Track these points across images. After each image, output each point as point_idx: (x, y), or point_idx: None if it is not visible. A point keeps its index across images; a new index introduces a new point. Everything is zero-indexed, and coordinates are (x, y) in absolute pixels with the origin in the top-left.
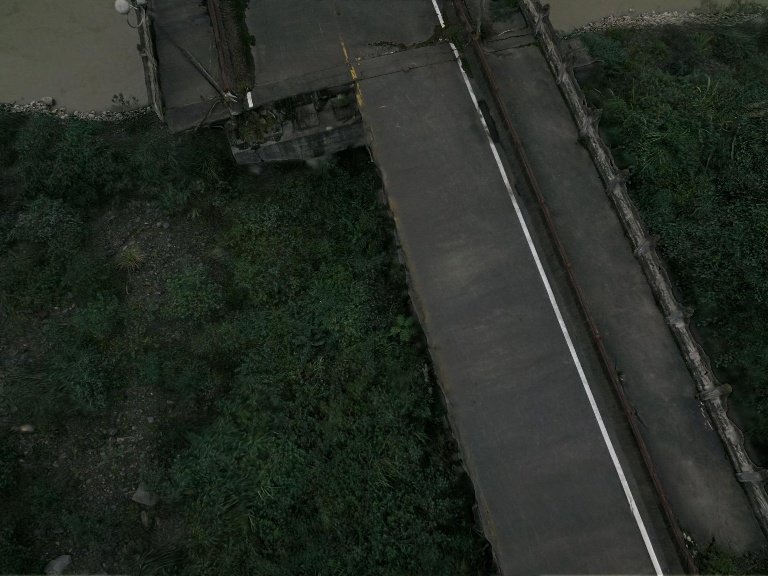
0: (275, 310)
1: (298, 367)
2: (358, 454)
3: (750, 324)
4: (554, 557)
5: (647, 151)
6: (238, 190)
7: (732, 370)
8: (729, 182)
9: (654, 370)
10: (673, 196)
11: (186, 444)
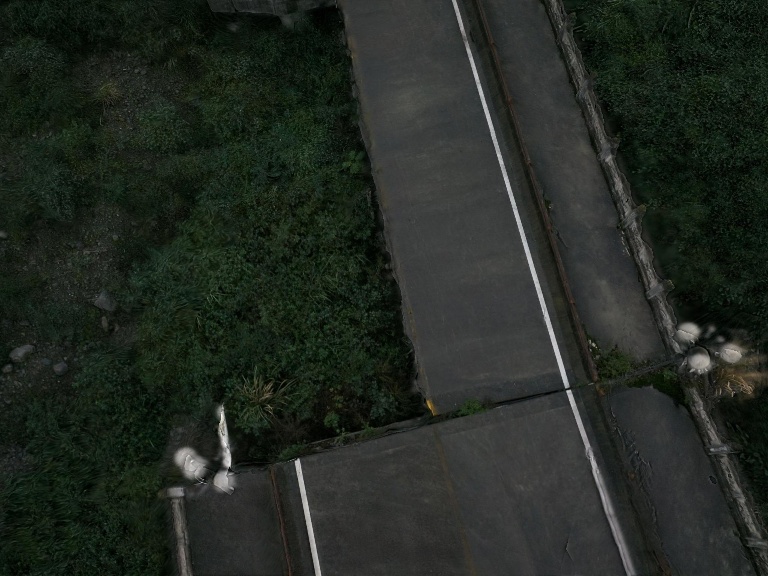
0: (237, 145)
1: (254, 196)
2: (302, 272)
3: (684, 175)
4: (468, 355)
5: (605, 14)
6: (213, 43)
7: (659, 213)
8: (683, 49)
9: (581, 201)
10: (625, 56)
11: (146, 260)
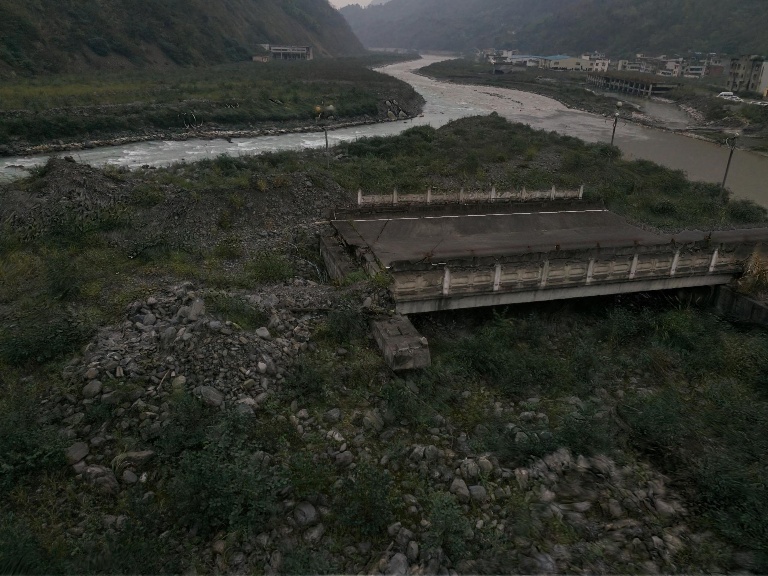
0: None
1: None
2: None
3: None
4: None
5: None
6: None
7: None
8: None
9: None
10: None
11: None
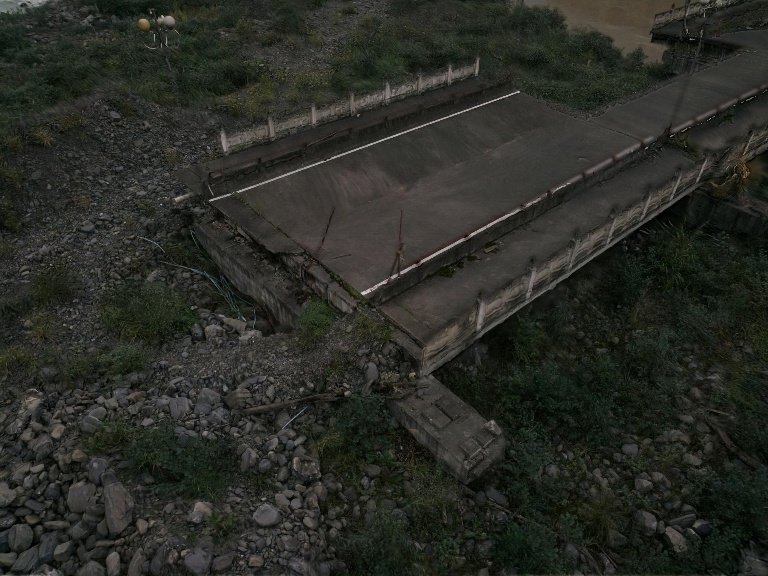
0: None
1: None
2: None
3: None
4: None
5: None
6: None
7: None
8: None
9: None
10: None
11: None
